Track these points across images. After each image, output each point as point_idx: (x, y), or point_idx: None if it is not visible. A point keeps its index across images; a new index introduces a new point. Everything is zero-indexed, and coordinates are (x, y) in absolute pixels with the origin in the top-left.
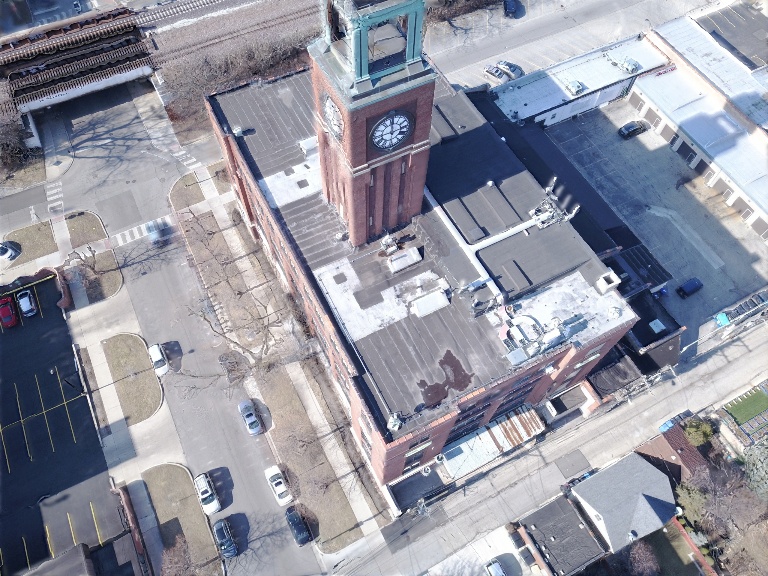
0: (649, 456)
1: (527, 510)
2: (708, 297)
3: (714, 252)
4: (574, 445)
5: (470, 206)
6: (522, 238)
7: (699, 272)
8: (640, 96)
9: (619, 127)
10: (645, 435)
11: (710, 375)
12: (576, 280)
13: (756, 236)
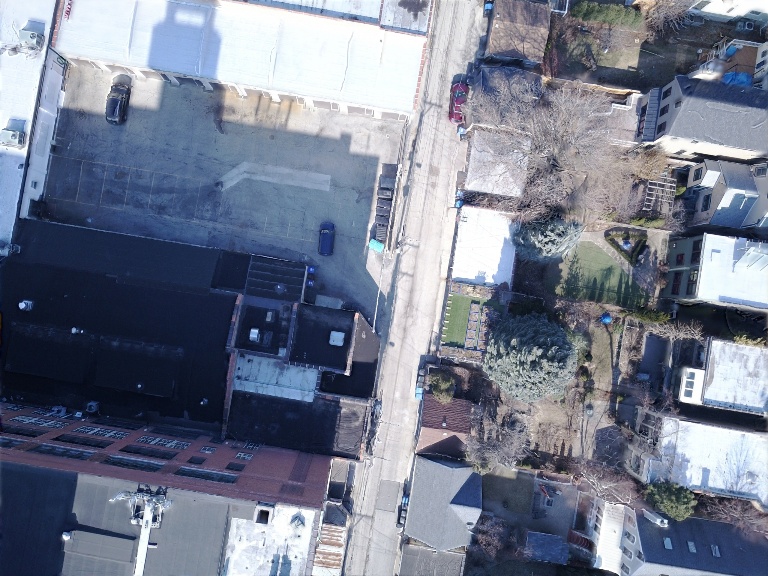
0: (429, 454)
1: (393, 565)
2: (347, 229)
3: (312, 173)
4: (375, 480)
5: (78, 575)
6: (155, 555)
7: (319, 210)
8: (81, 59)
9: (103, 113)
10: (412, 413)
11: (410, 305)
12: (239, 527)
13: (328, 114)
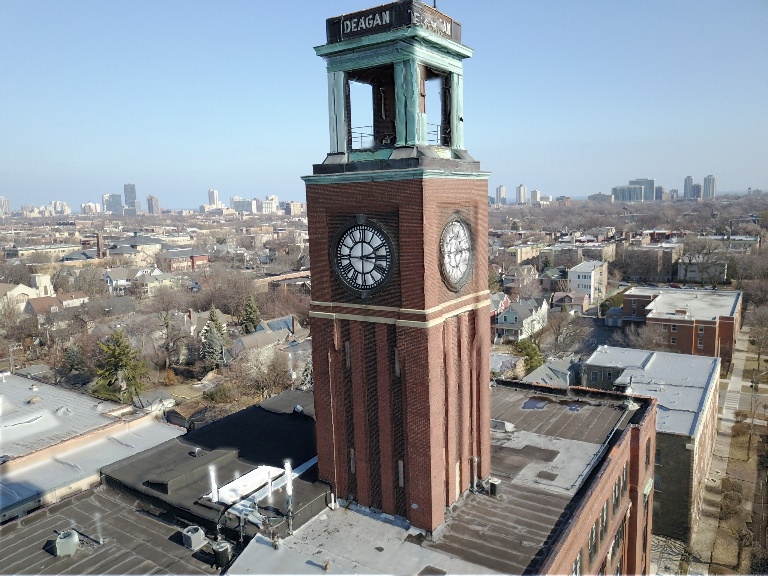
0: None
1: None
2: None
3: None
4: None
5: None
6: None
7: None
8: None
9: None
10: None
11: None
12: None
13: None
